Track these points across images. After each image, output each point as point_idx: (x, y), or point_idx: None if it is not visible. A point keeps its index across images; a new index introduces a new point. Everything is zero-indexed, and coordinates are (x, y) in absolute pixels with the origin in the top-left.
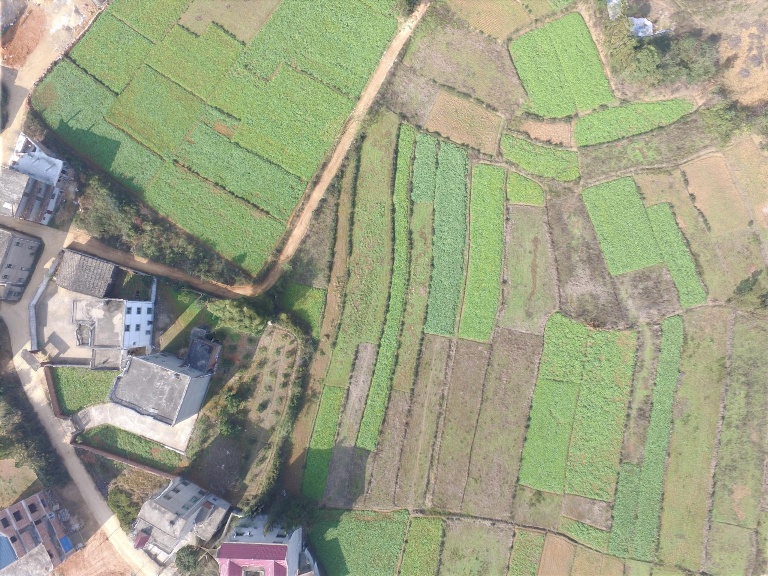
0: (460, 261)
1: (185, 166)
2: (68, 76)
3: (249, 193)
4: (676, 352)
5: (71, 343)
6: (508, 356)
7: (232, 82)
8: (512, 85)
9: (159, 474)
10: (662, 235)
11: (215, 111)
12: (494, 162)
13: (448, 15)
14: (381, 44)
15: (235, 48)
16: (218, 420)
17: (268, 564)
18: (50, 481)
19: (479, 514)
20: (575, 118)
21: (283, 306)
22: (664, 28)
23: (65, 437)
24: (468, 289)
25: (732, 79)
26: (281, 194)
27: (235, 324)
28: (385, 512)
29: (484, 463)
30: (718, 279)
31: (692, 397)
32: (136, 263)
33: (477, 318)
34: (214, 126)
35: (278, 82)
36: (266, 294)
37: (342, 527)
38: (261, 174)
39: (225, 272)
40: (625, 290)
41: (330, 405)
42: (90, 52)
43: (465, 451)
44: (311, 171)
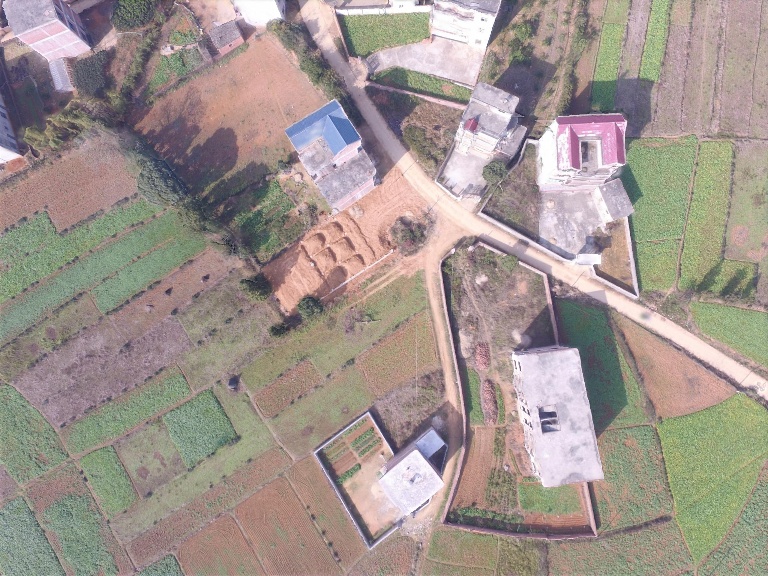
0: None
1: None
2: None
3: None
4: None
5: None
6: None
7: None
8: None
9: (456, 103)
10: None
11: None
12: None
13: None
14: None
15: None
16: (505, 56)
17: (606, 130)
18: (351, 113)
19: (767, 136)
20: None
21: None
22: None
23: (356, 81)
24: None
25: None
26: None
27: None
28: (673, 138)
29: (767, 89)
30: None
31: None
32: None
33: None
34: None
35: None
36: None
37: (632, 153)
38: None
39: None
40: None
41: (611, 40)
42: None
43: (748, 78)
44: None
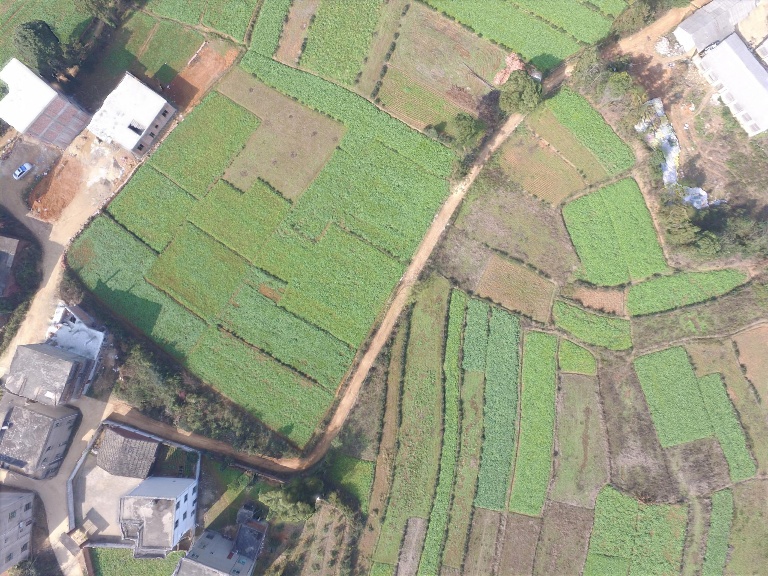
0: (511, 432)
1: (230, 331)
2: (106, 232)
3: (296, 360)
4: (726, 527)
5: (111, 520)
6: (559, 530)
7: (279, 242)
8: (565, 252)
9: None
10: (713, 407)
11: (261, 273)
12: (546, 330)
13: (501, 177)
14: (433, 206)
15: (282, 207)
16: None
17: None
18: None
19: None
20: (628, 287)
21: (331, 480)
22: (719, 198)
23: None
24: (519, 461)
25: None
26: (329, 362)
27: (288, 519)
28: None
29: None
30: (767, 452)
31: (741, 572)
32: (179, 436)
33: (528, 492)
34: (260, 289)
35: (326, 243)
36: (314, 468)
37: None
38: (309, 341)
39: (272, 446)
40: (676, 462)
41: None
42: (129, 207)
43: None
44: (360, 338)
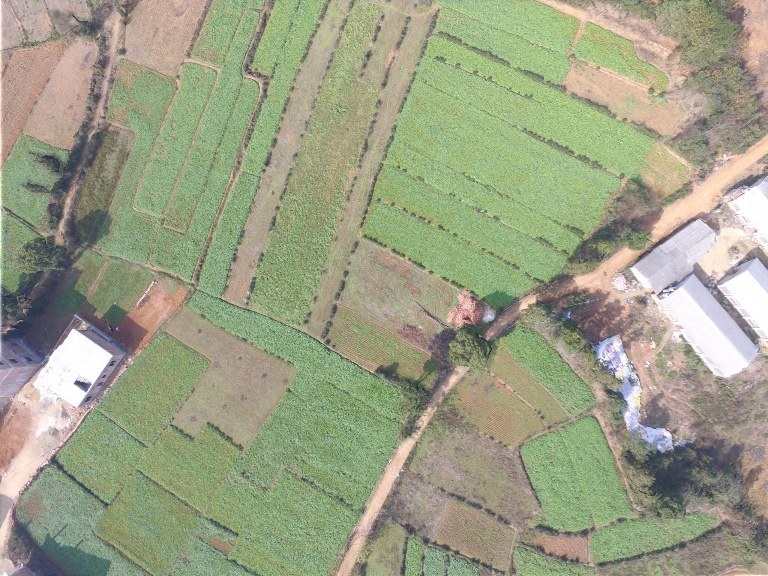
0: None
1: None
2: (55, 484)
3: None
4: None
5: None
6: None
7: (229, 491)
8: (525, 496)
9: None
10: None
11: (211, 525)
12: None
13: (456, 418)
14: (386, 451)
15: (232, 454)
16: None
17: None
18: None
19: None
20: (592, 532)
21: None
22: (684, 438)
23: None
24: None
25: (757, 494)
26: None
27: None
28: None
29: None
30: None
31: None
32: None
33: None
34: (210, 541)
35: (277, 491)
36: None
37: None
38: None
39: None
40: None
41: None
42: (78, 457)
43: None
44: None
